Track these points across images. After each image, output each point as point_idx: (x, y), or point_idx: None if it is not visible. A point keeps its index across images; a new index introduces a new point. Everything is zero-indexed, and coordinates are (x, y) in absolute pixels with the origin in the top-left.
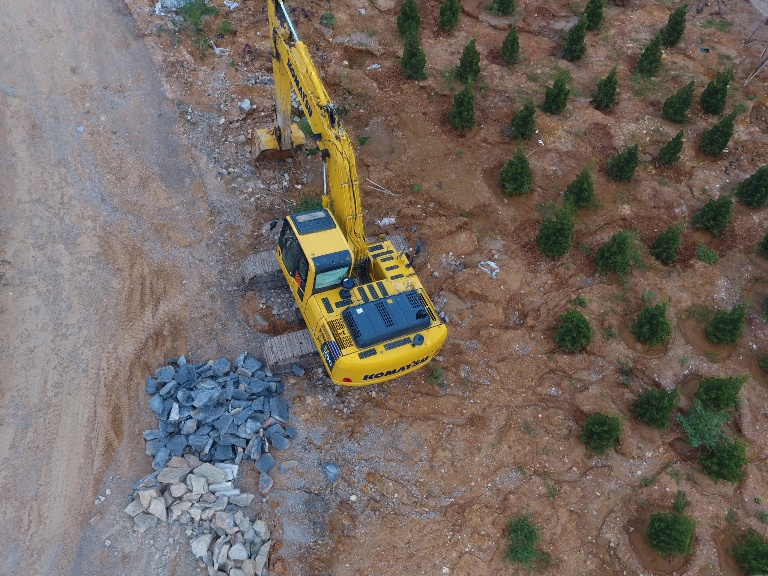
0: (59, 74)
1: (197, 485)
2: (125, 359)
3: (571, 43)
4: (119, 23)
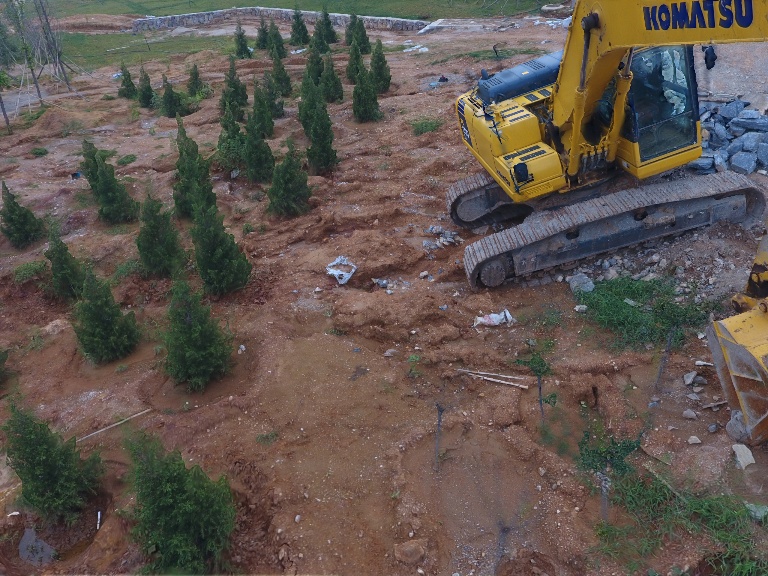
0: None
1: None
2: None
3: None
4: None
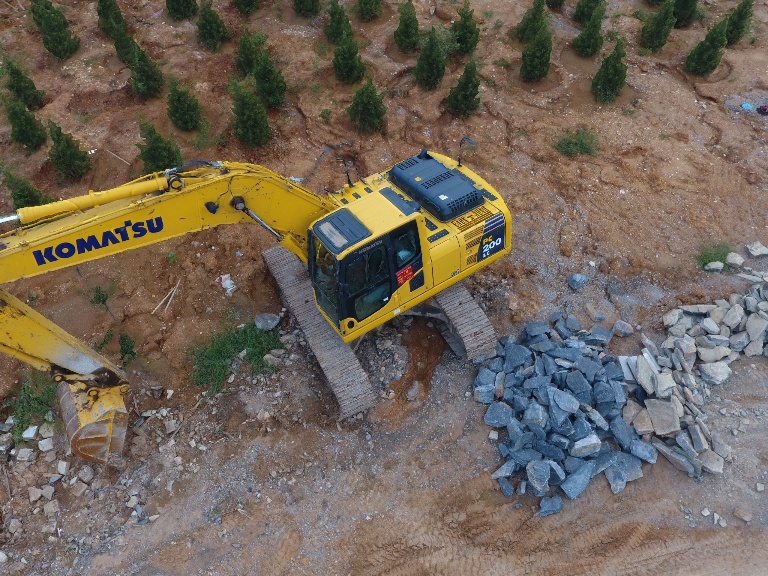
0: None
1: (667, 382)
2: (519, 568)
3: None
4: None
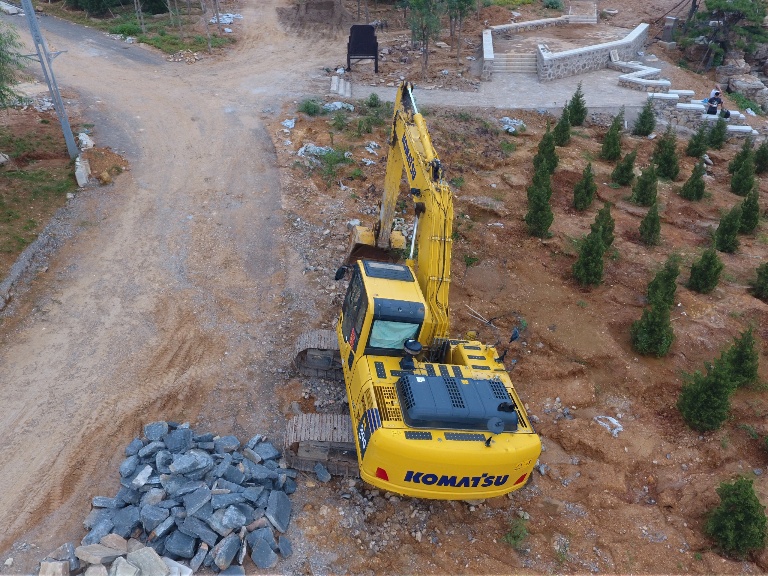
0: (193, 180)
1: (122, 575)
2: (121, 413)
3: (722, 233)
4: (262, 156)
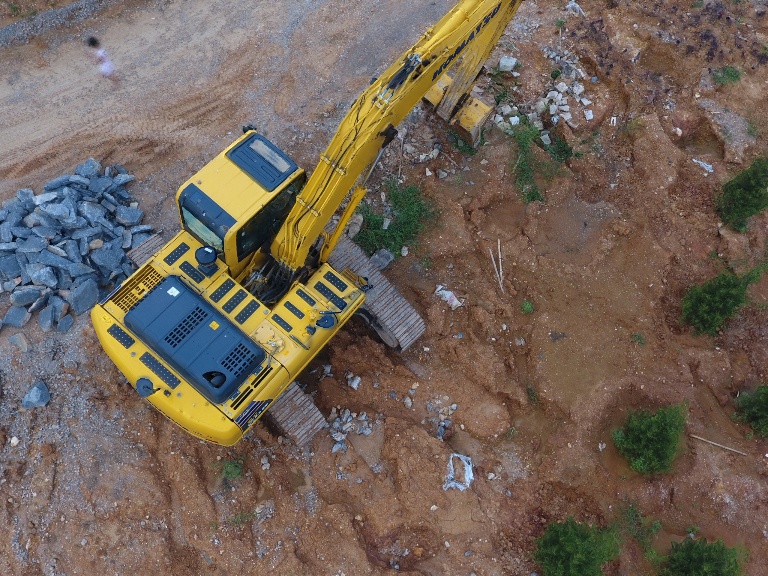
0: None
1: None
2: (113, 133)
3: None
4: None
